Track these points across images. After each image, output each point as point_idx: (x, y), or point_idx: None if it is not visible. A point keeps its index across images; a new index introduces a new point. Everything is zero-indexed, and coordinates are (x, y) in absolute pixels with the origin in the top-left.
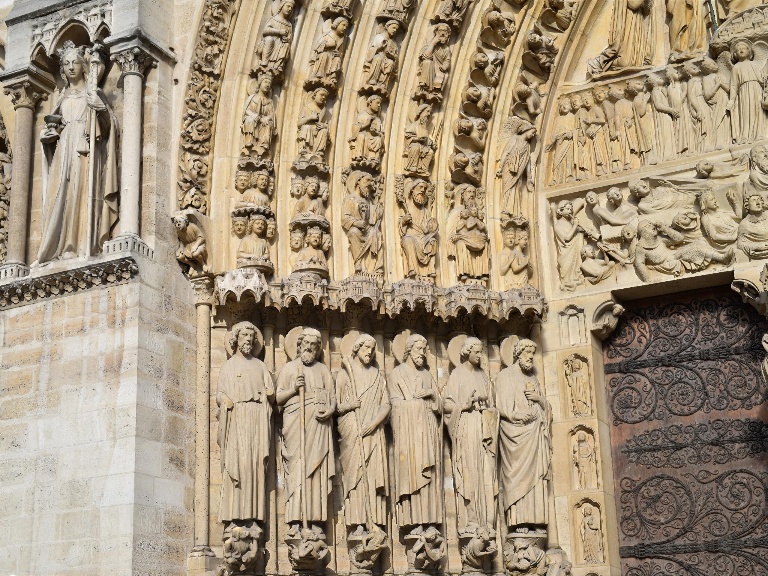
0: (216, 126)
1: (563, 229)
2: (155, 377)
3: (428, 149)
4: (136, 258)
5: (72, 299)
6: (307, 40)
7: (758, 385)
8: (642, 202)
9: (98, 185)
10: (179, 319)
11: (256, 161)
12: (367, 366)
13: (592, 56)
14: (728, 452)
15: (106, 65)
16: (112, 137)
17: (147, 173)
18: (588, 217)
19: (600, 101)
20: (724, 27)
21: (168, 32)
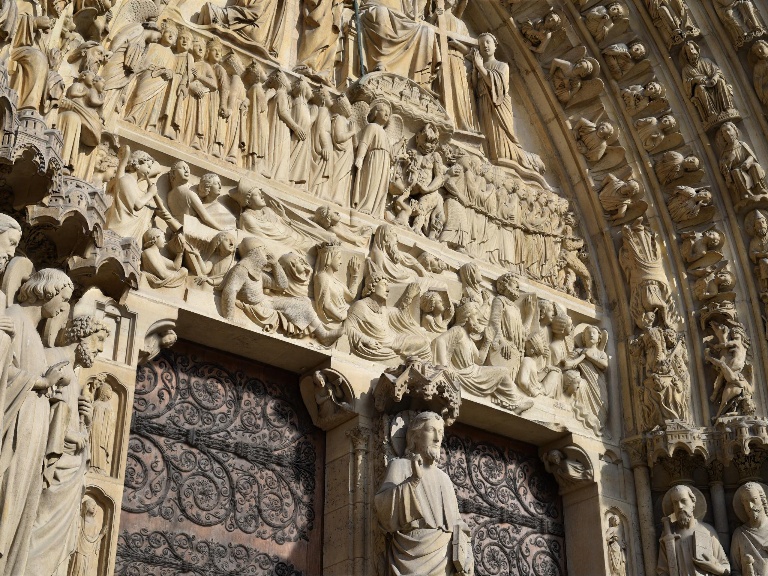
0: None
1: (136, 189)
2: None
3: None
4: None
5: None
6: None
7: (296, 515)
8: (251, 214)
9: None
10: None
11: None
12: None
13: (204, 1)
14: None
15: None
16: None
17: None
18: (158, 193)
19: (214, 60)
20: (376, 76)
21: None
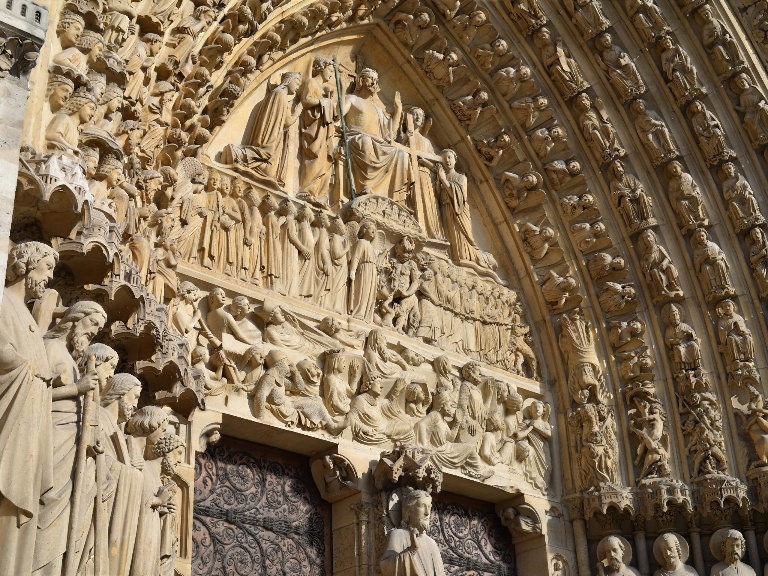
0: None
1: None
2: None
3: None
4: None
5: None
6: None
7: (312, 575)
8: (274, 329)
9: None
10: None
11: (99, 18)
12: None
13: (224, 141)
14: None
15: None
16: None
17: None
18: None
19: (237, 195)
20: None
21: None
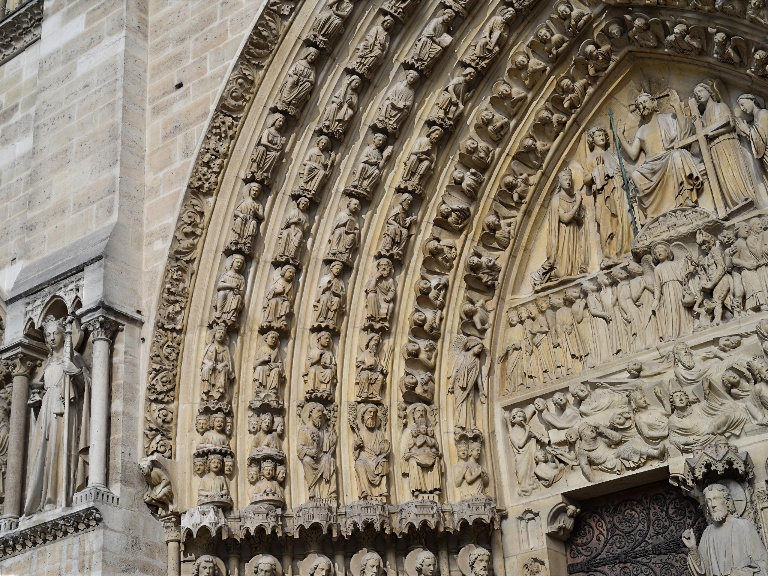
0: (181, 376)
1: (516, 436)
2: None
3: (377, 375)
4: (99, 507)
5: (52, 547)
6: (260, 289)
7: None
8: (582, 405)
9: (74, 441)
10: (148, 557)
11: (212, 405)
12: None
13: (537, 268)
14: None
15: (85, 331)
16: (86, 397)
17: (114, 427)
18: (540, 422)
19: (543, 311)
20: (642, 233)
21: (136, 297)
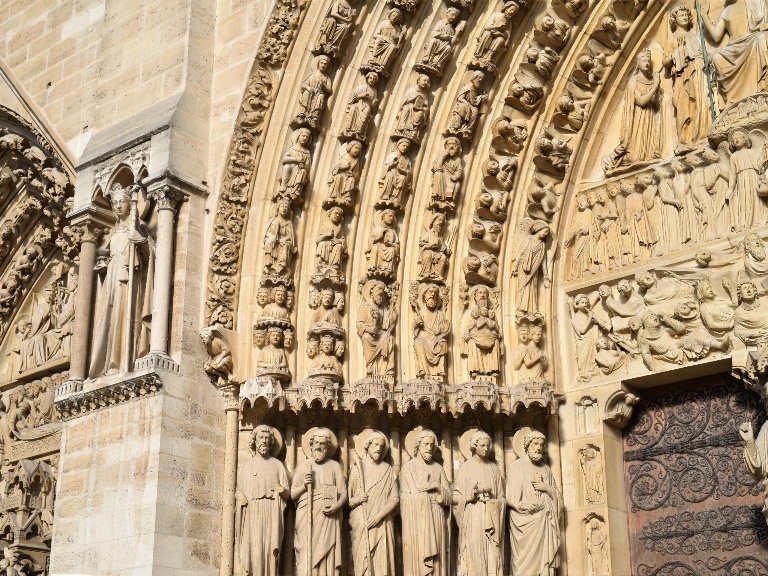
0: (244, 248)
1: (579, 322)
2: (178, 478)
3: (440, 255)
4: (160, 373)
5: (115, 410)
6: (325, 164)
7: None
8: (647, 293)
9: (138, 308)
10: (207, 425)
11: (274, 278)
12: (378, 462)
13: (609, 152)
14: (736, 539)
15: (151, 201)
16: (150, 265)
17: (177, 296)
18: (604, 309)
19: (613, 196)
20: (720, 118)
21: (201, 168)
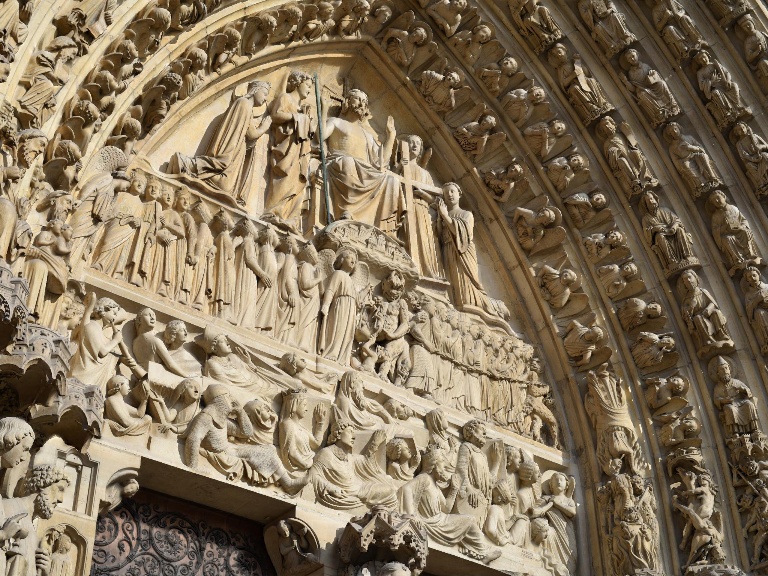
0: None
1: (101, 336)
2: None
3: None
4: None
5: None
6: None
7: None
8: (216, 361)
9: None
10: None
11: None
12: None
13: (173, 151)
14: None
15: None
16: None
17: None
18: (124, 339)
19: (182, 208)
20: (343, 224)
21: None
